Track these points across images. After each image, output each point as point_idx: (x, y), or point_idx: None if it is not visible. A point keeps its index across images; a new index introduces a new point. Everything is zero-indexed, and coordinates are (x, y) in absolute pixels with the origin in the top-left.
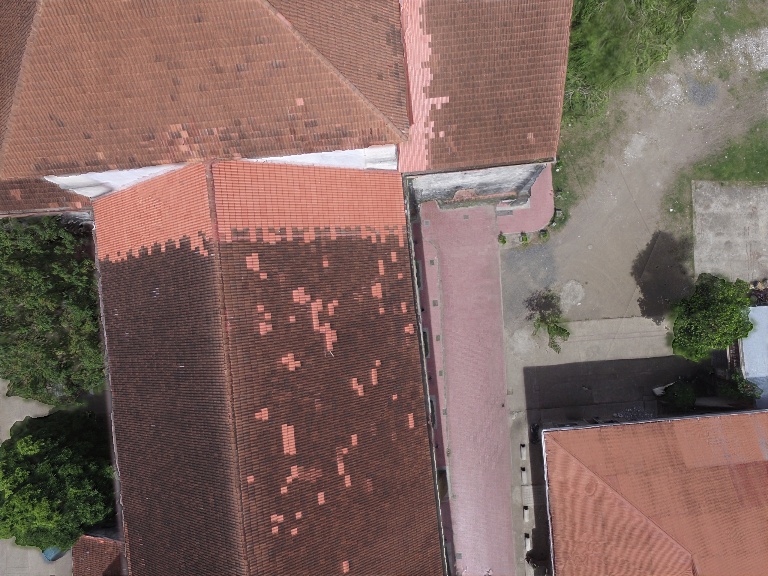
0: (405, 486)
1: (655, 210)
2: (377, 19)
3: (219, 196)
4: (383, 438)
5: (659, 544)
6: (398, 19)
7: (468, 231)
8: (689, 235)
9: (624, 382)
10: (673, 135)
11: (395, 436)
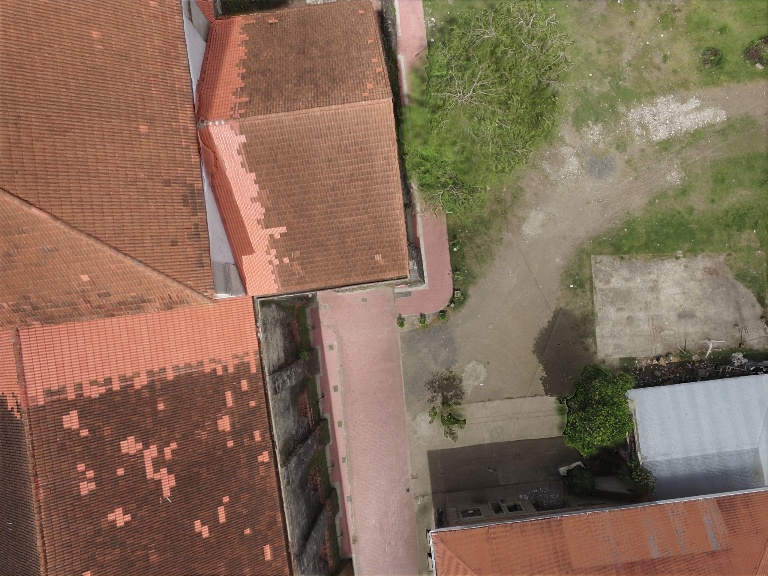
0: None
1: (555, 286)
2: (170, 182)
3: (29, 358)
4: None
5: None
6: (199, 176)
7: (367, 314)
8: (590, 311)
9: (529, 462)
10: (571, 209)
11: (247, 572)
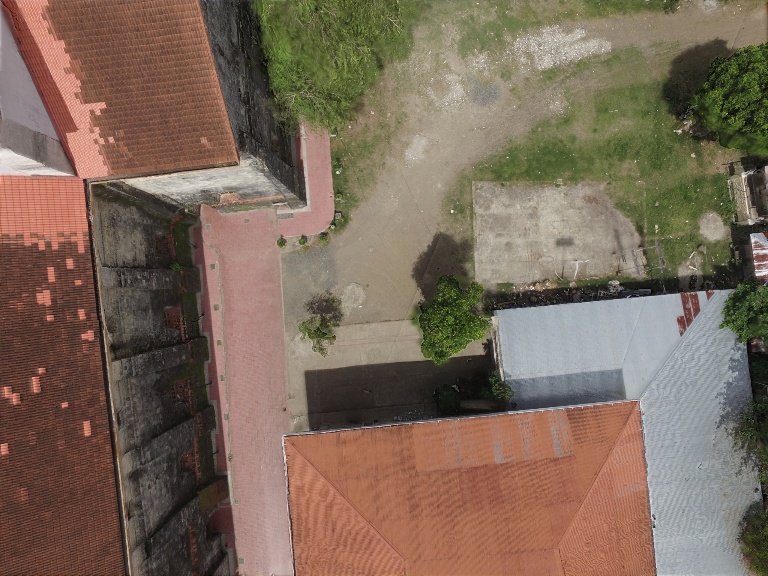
0: (75, 494)
1: (436, 211)
2: None
3: None
4: (46, 446)
5: (378, 549)
6: None
7: (249, 235)
8: (470, 236)
9: (405, 385)
10: (454, 136)
11: (62, 444)
